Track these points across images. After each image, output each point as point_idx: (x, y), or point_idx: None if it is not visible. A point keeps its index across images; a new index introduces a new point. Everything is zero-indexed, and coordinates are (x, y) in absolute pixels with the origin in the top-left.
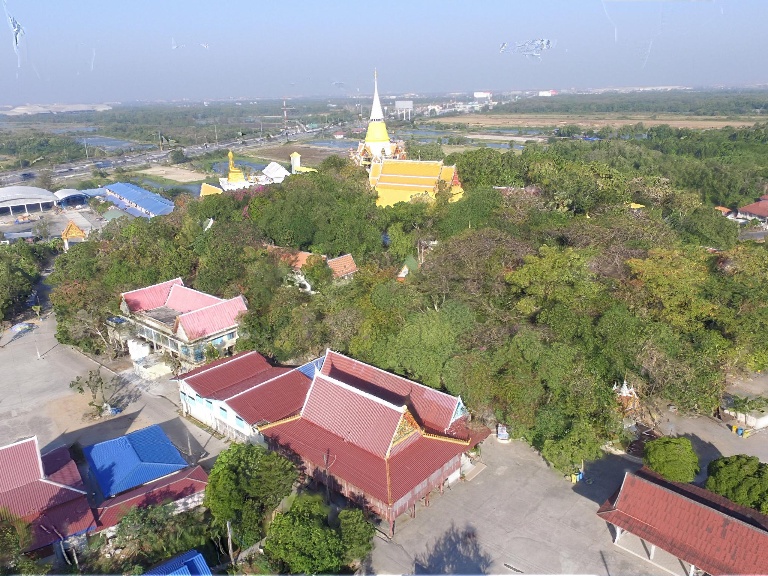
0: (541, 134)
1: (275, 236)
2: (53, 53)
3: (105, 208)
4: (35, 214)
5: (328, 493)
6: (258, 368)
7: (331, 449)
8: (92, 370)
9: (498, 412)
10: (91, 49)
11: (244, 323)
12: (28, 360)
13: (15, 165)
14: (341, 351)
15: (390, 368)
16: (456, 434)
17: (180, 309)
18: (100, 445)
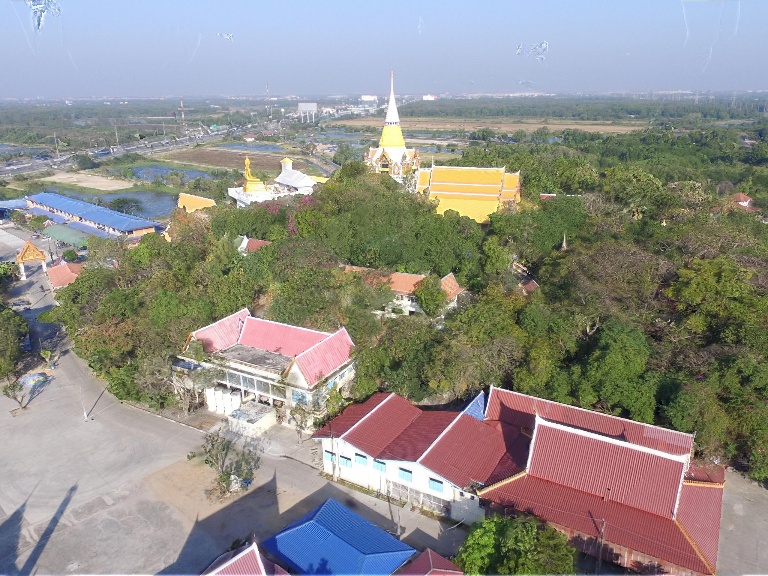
0: (455, 137)
1: (345, 255)
2: (121, 37)
3: (40, 223)
4: None
5: (600, 565)
6: (409, 414)
7: (593, 511)
8: (211, 435)
9: (731, 446)
10: (196, 33)
11: (367, 360)
12: (73, 423)
13: None
14: (498, 386)
15: (575, 403)
16: (695, 475)
17: (263, 346)
18: (284, 536)
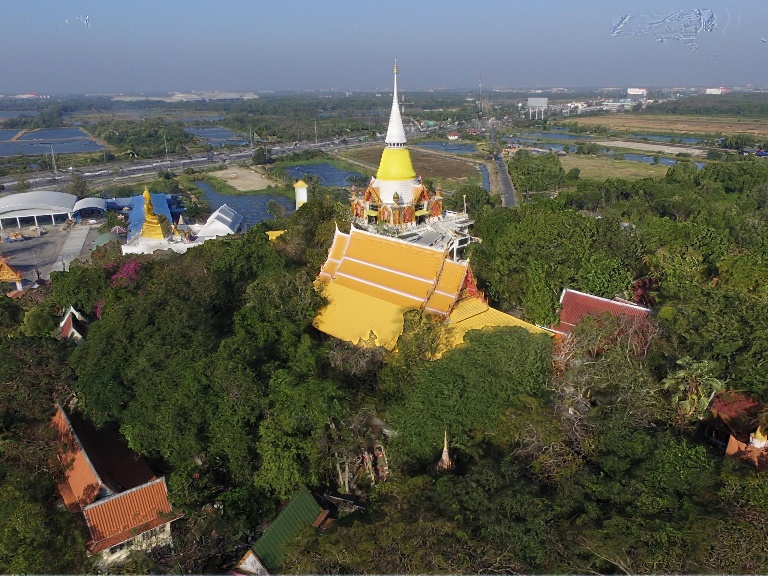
0: (700, 144)
1: None
2: None
3: (106, 229)
4: (43, 228)
5: None
6: None
7: None
8: None
9: None
10: None
11: None
12: None
13: (100, 159)
14: None
15: None
16: None
17: None
18: None
